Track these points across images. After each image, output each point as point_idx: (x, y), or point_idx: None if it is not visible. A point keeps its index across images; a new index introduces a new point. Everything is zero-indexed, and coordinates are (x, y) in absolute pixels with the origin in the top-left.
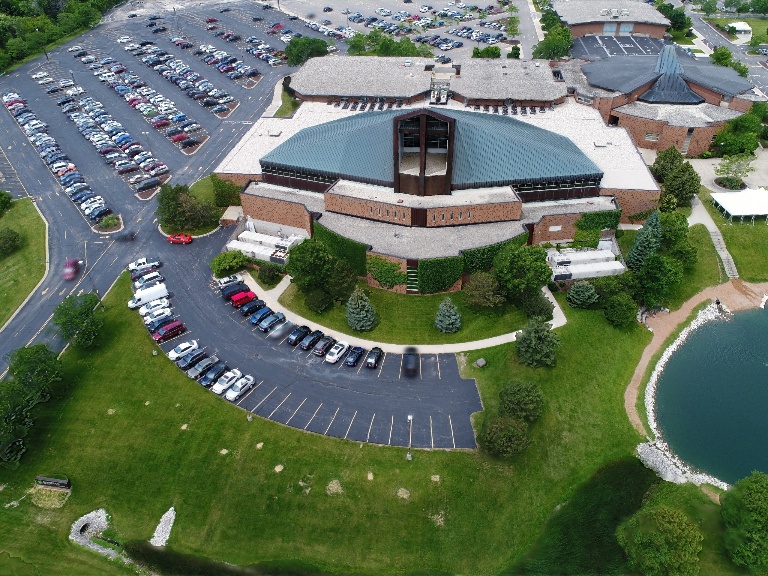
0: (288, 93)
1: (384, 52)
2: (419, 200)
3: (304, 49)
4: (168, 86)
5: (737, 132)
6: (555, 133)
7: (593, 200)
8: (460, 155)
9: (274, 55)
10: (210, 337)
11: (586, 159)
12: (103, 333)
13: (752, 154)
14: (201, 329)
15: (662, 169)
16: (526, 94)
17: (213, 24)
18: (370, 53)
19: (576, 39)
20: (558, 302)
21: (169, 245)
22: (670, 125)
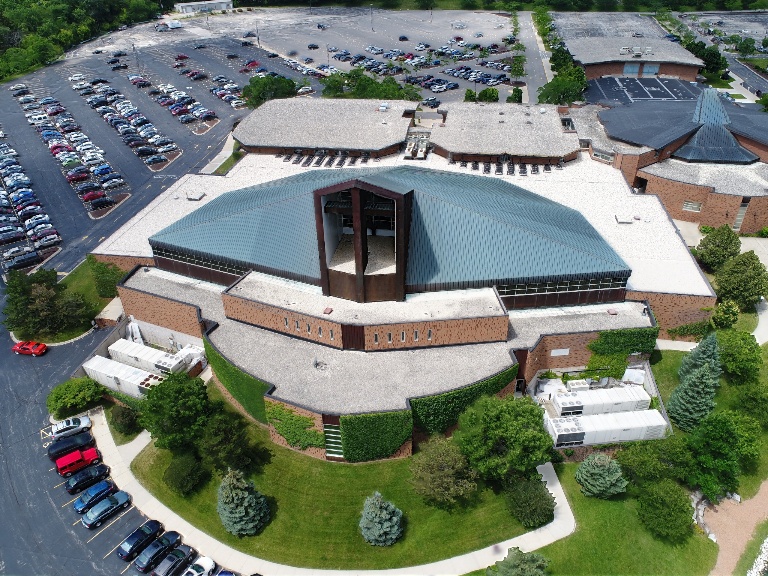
0: None
1: (360, 94)
2: (356, 309)
3: (266, 89)
4: (105, 131)
5: None
6: (562, 205)
7: (616, 308)
8: (420, 242)
9: None
10: (2, 537)
11: (605, 247)
12: None
13: None
14: None
15: (711, 255)
16: (526, 148)
17: (182, 61)
18: (350, 95)
19: (591, 81)
20: (562, 484)
21: (13, 357)
22: (718, 193)
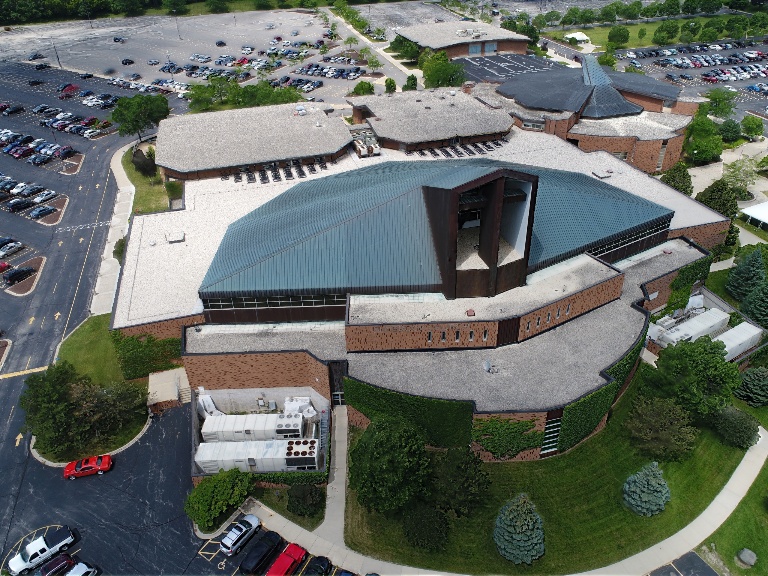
0: (142, 172)
1: (250, 102)
2: (494, 304)
3: (140, 111)
4: None
5: (697, 137)
6: None
7: (666, 247)
8: None
9: (85, 125)
10: None
11: (639, 197)
12: None
13: (719, 158)
14: None
15: None
16: (472, 128)
17: None
18: (217, 106)
19: None
20: None
21: (71, 485)
22: (643, 140)
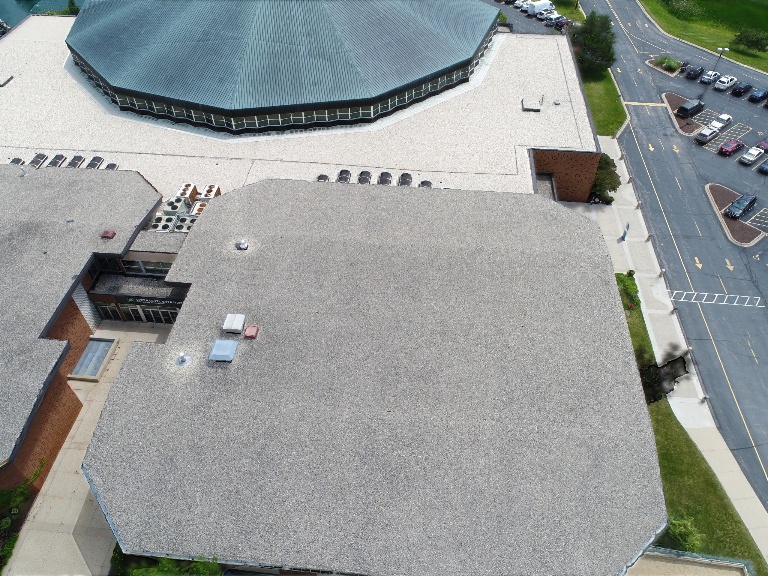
0: None
1: None
2: None
3: None
4: None
5: None
6: (77, 43)
7: None
8: None
9: None
10: None
11: (89, 3)
12: (557, 1)
13: None
14: (484, 1)
15: None
16: None
17: None
18: None
19: None
20: None
21: None
22: None
